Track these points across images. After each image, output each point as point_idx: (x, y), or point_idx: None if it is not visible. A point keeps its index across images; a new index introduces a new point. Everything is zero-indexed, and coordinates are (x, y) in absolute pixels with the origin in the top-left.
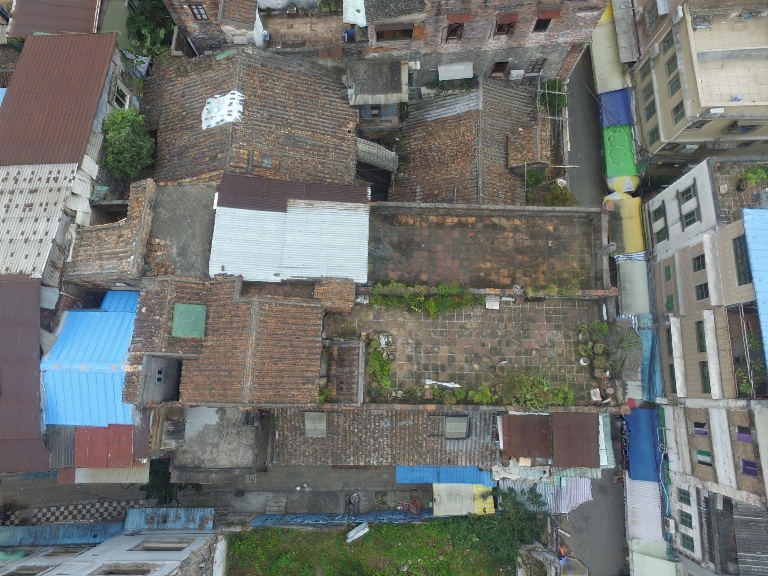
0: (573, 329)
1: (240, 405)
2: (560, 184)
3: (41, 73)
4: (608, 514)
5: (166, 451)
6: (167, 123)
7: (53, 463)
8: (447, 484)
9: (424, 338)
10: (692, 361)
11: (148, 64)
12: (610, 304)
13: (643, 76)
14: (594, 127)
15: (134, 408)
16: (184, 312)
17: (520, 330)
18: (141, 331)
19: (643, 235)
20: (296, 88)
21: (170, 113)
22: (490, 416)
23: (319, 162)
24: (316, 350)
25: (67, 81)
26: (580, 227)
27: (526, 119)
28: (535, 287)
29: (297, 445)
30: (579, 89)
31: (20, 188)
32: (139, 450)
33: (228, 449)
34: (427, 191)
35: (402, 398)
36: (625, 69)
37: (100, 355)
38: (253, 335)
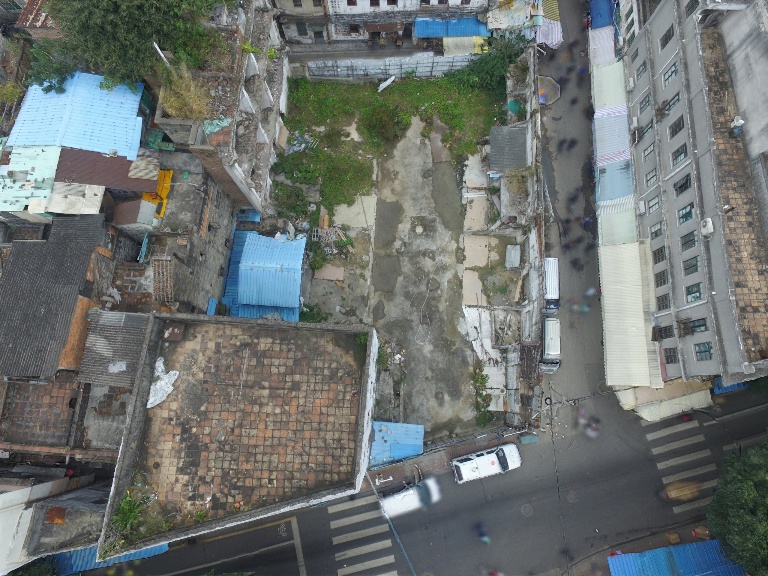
0: None
1: None
2: None
3: None
4: (577, 76)
5: None
6: None
7: None
8: (454, 38)
9: None
10: None
11: None
12: None
13: None
14: None
15: None
16: None
17: None
18: None
19: None
20: None
21: None
22: None
23: None
24: None
25: None
26: None
27: None
28: None
29: None
30: None
31: None
32: None
33: None
34: None
35: None
36: None
37: None
38: None
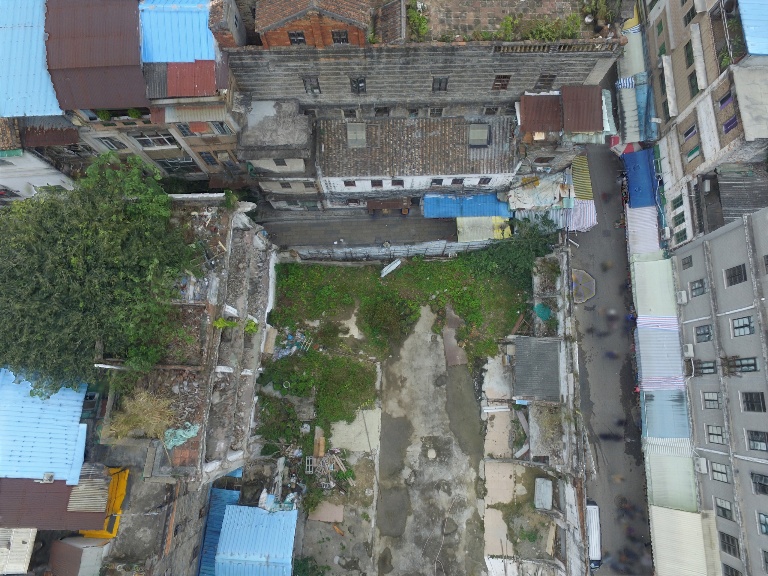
0: None
1: (309, 8)
2: None
3: None
4: (612, 253)
5: (233, 135)
6: None
7: (149, 94)
8: (469, 218)
9: (453, 7)
10: (682, 81)
11: None
12: None
13: None
14: None
15: (216, 45)
16: None
17: (534, 1)
18: None
19: (638, 10)
20: None
21: None
22: (507, 124)
23: None
24: None
25: None
26: None
27: None
28: None
29: (340, 158)
30: None
31: None
32: (220, 83)
33: (285, 133)
34: None
35: None
36: None
37: (187, 1)
38: None
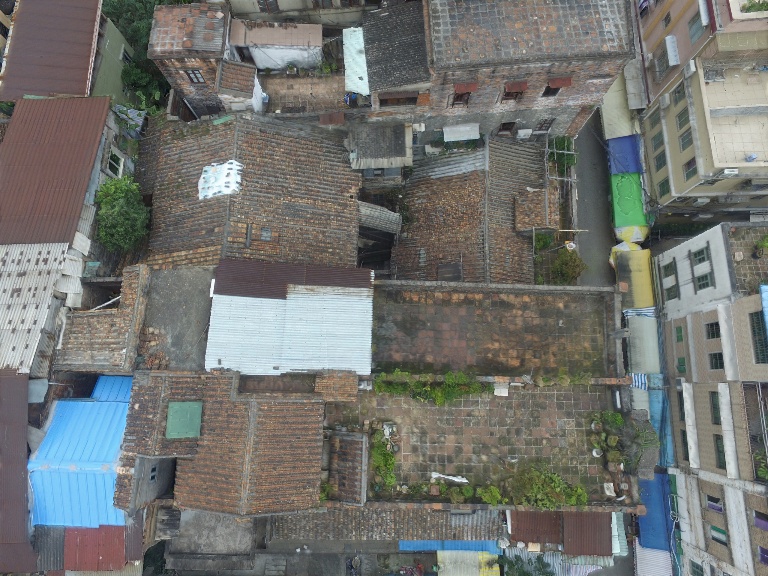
0: (585, 416)
1: (237, 517)
2: (569, 247)
3: (31, 141)
4: None
5: None
6: (162, 189)
7: (41, 565)
8: (452, 551)
9: (430, 427)
10: (706, 432)
11: (143, 118)
12: (624, 393)
13: (652, 124)
14: (601, 171)
15: None
16: (179, 411)
17: (530, 417)
18: (134, 429)
19: (653, 290)
20: (296, 153)
21: (166, 178)
22: None
23: (320, 231)
24: (317, 450)
25: (58, 150)
26: (592, 304)
27: (533, 177)
28: (545, 369)
29: (297, 519)
30: (586, 131)
31: (8, 271)
32: (132, 551)
33: (225, 533)
34: (431, 253)
35: (407, 493)
36: (634, 115)
37: (91, 453)
38: (251, 439)
